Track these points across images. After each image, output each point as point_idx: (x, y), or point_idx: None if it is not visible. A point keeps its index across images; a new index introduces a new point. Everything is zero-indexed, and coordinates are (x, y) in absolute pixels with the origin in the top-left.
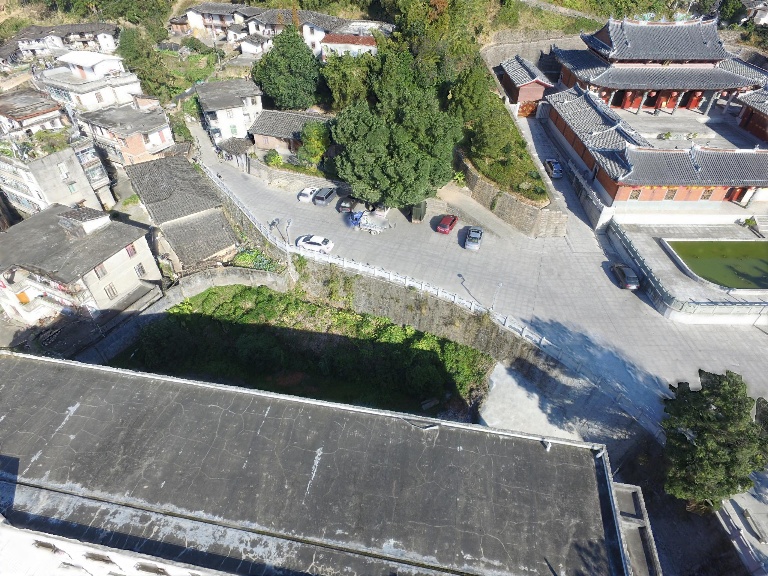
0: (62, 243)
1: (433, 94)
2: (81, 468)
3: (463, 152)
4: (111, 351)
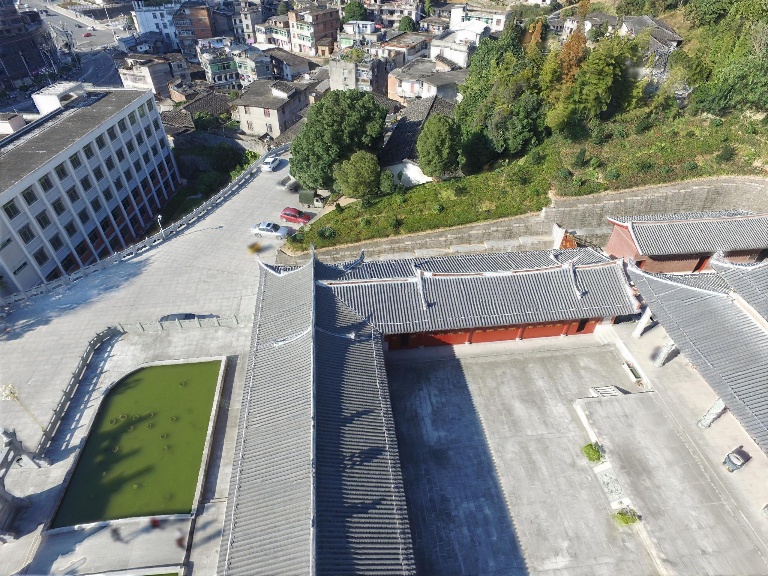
0: None
1: (345, 102)
2: None
3: None
4: None
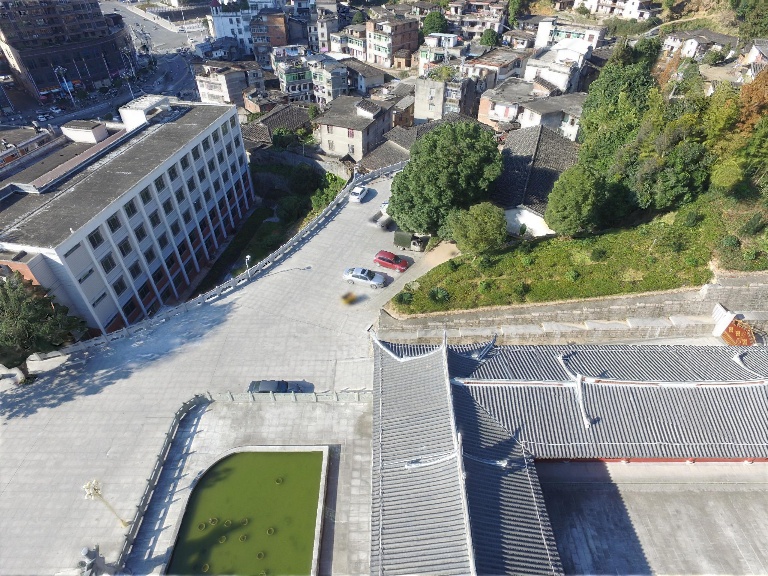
0: (350, 112)
1: (464, 142)
2: (162, 131)
3: (503, 247)
4: None
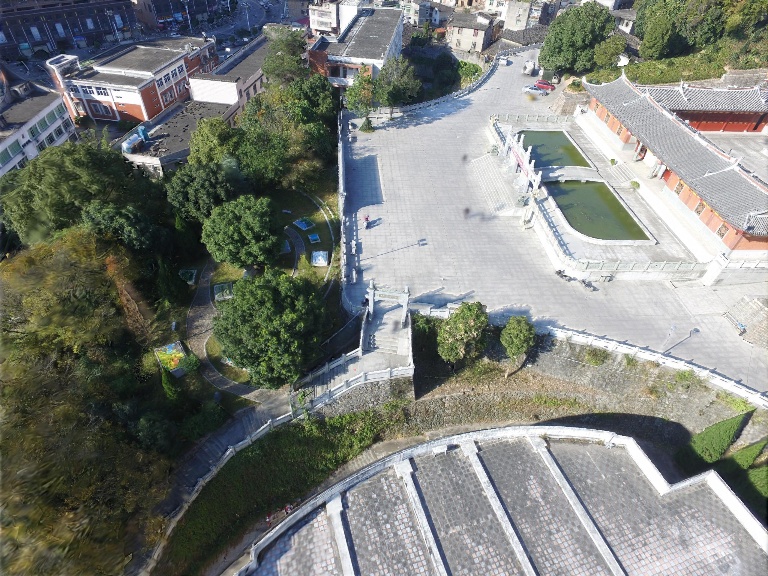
0: None
1: None
2: None
3: None
4: (435, 56)
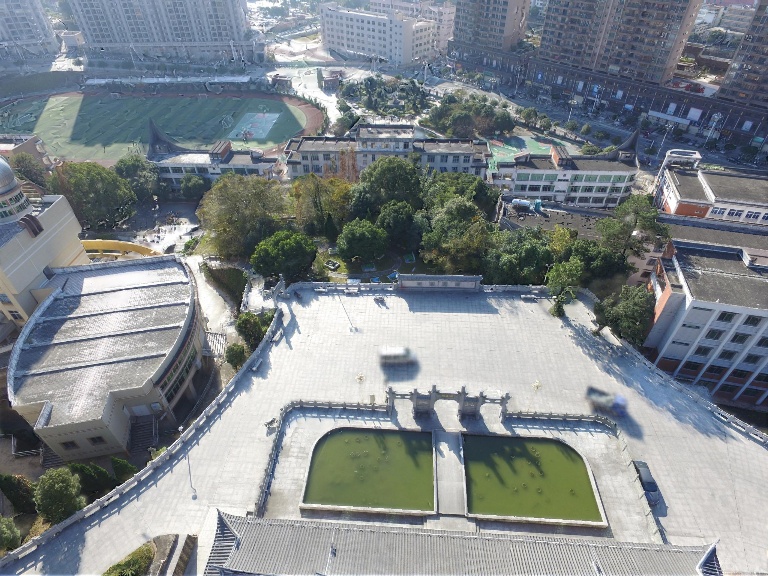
0: None
1: None
2: None
3: None
4: None
